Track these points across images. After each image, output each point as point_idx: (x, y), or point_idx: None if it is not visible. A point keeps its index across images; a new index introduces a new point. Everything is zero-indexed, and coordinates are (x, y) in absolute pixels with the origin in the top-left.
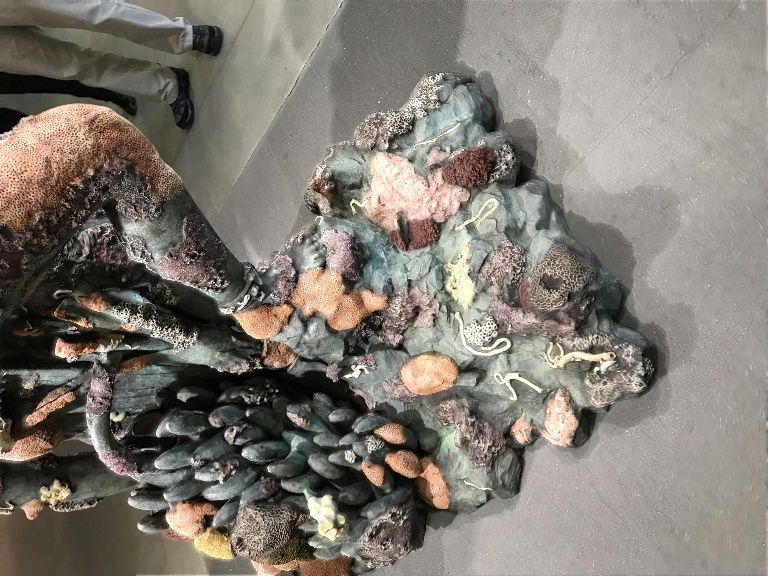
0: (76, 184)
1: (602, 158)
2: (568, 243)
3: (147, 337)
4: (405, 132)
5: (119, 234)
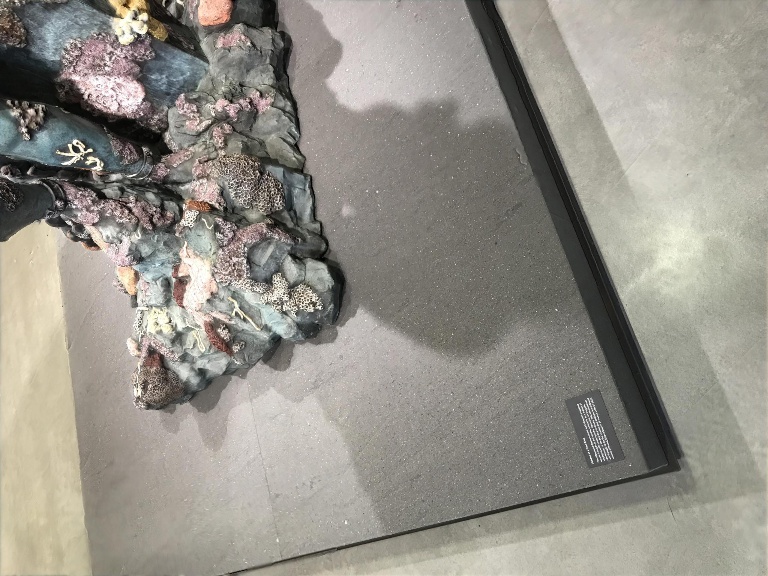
0: None
1: (246, 415)
2: (190, 386)
3: None
4: None
5: None
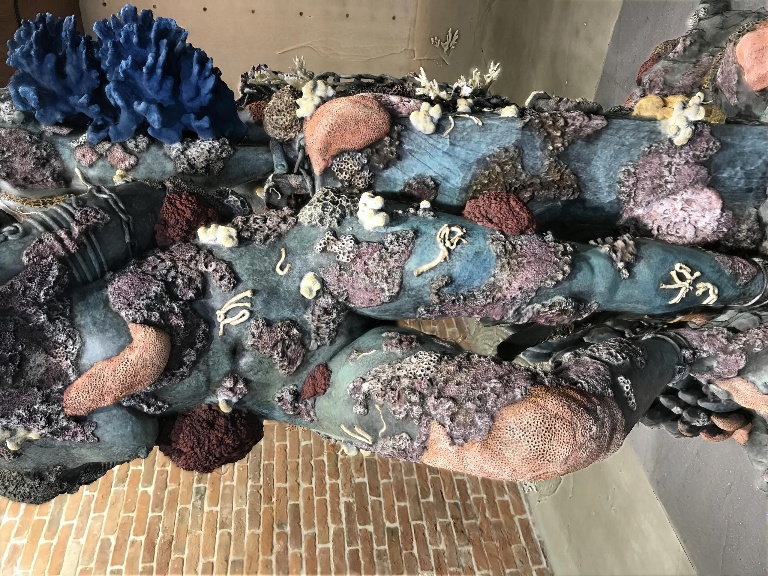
0: None
1: None
2: None
3: None
4: None
5: None
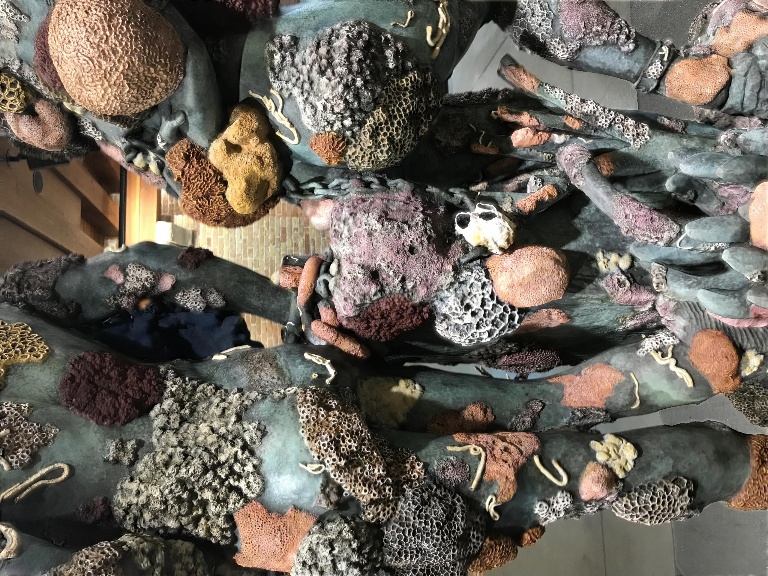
0: None
1: None
2: None
3: None
4: None
5: (516, 13)
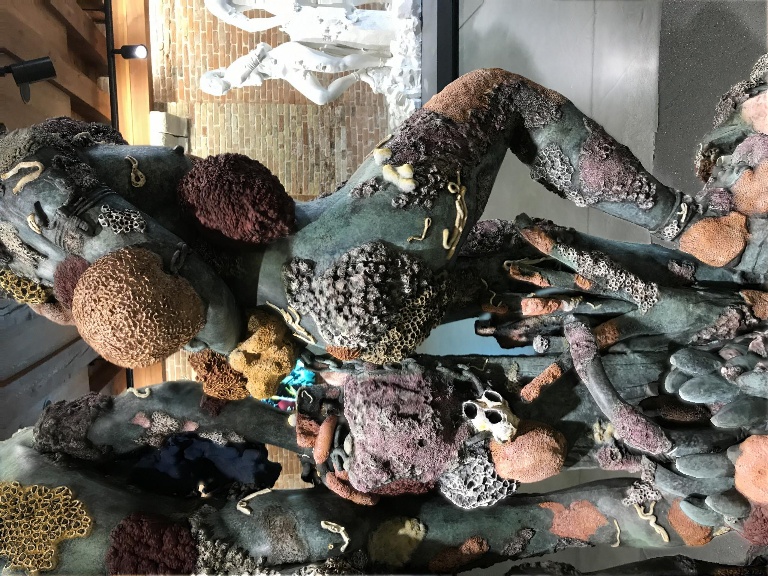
0: (488, 93)
1: None
2: None
3: (605, 299)
4: (758, 85)
5: (536, 159)
